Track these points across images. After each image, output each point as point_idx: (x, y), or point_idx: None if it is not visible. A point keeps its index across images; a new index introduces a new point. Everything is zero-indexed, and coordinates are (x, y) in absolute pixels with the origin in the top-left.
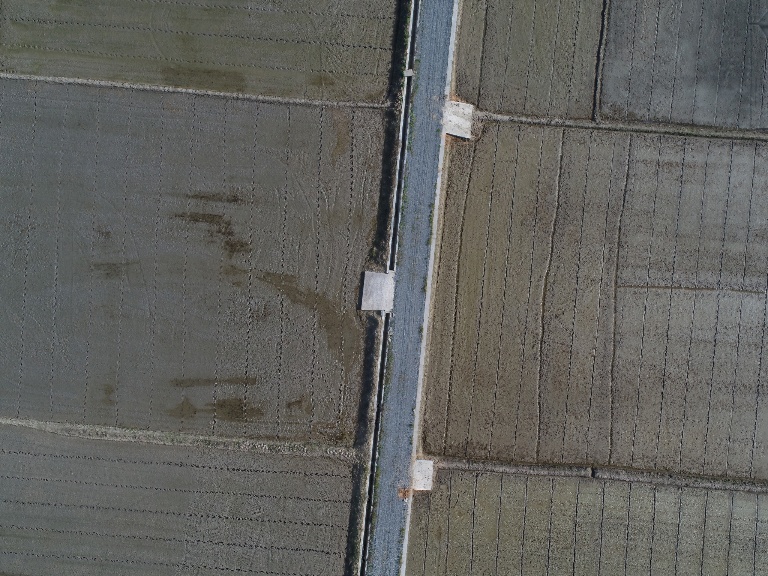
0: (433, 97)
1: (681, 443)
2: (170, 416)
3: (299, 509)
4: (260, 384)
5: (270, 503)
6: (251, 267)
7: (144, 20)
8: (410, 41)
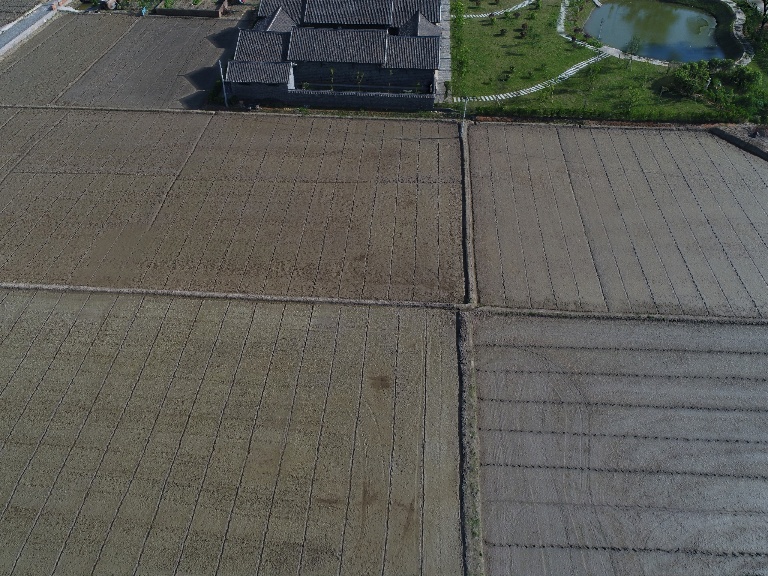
0: None
1: (7, 260)
2: None
3: None
4: None
5: None
6: None
7: None
8: None
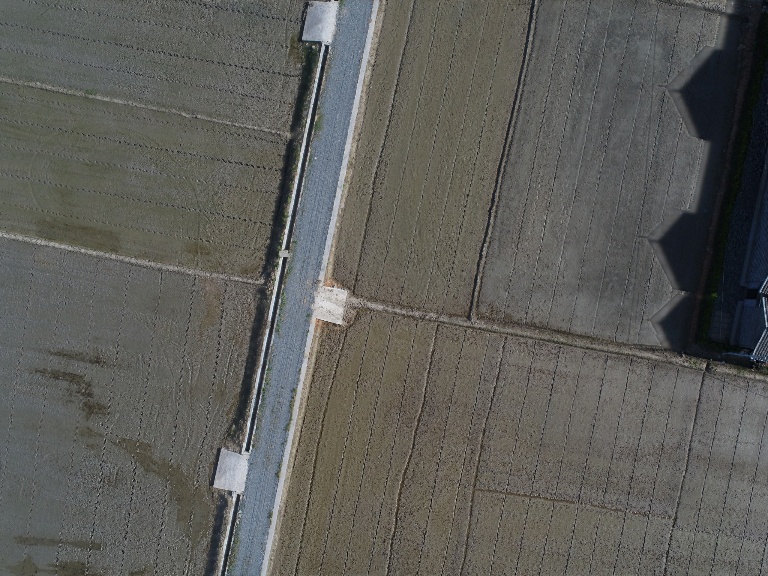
0: (306, 281)
1: None
2: (11, 573)
3: None
4: (104, 550)
5: None
6: (107, 431)
7: (24, 169)
8: (290, 220)
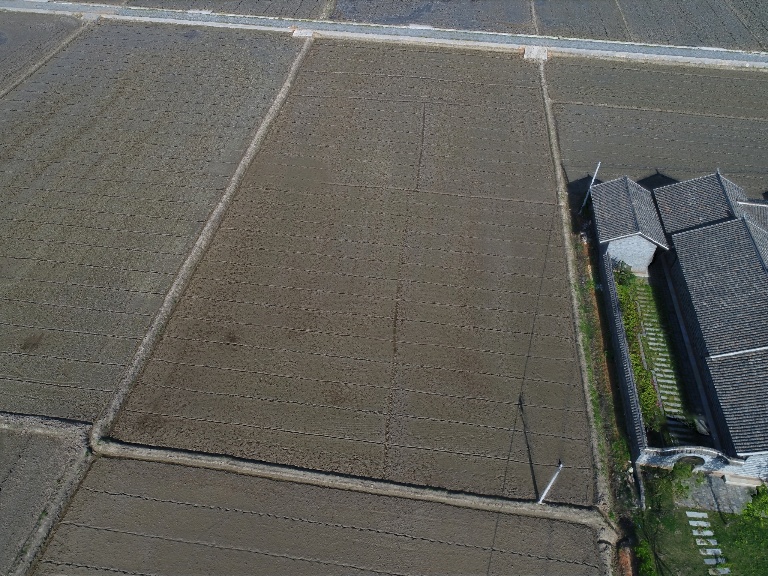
0: None
1: None
2: None
3: (293, 7)
4: (368, 2)
5: (299, 1)
6: (435, 2)
7: None
8: None
